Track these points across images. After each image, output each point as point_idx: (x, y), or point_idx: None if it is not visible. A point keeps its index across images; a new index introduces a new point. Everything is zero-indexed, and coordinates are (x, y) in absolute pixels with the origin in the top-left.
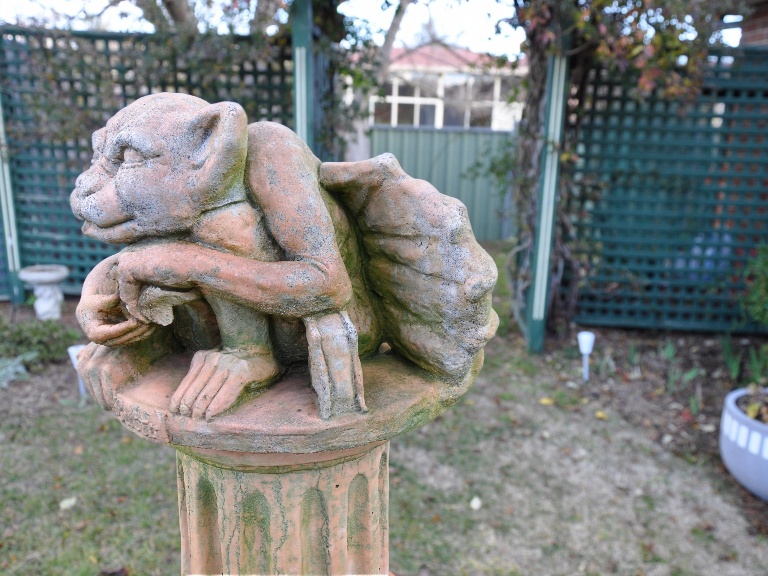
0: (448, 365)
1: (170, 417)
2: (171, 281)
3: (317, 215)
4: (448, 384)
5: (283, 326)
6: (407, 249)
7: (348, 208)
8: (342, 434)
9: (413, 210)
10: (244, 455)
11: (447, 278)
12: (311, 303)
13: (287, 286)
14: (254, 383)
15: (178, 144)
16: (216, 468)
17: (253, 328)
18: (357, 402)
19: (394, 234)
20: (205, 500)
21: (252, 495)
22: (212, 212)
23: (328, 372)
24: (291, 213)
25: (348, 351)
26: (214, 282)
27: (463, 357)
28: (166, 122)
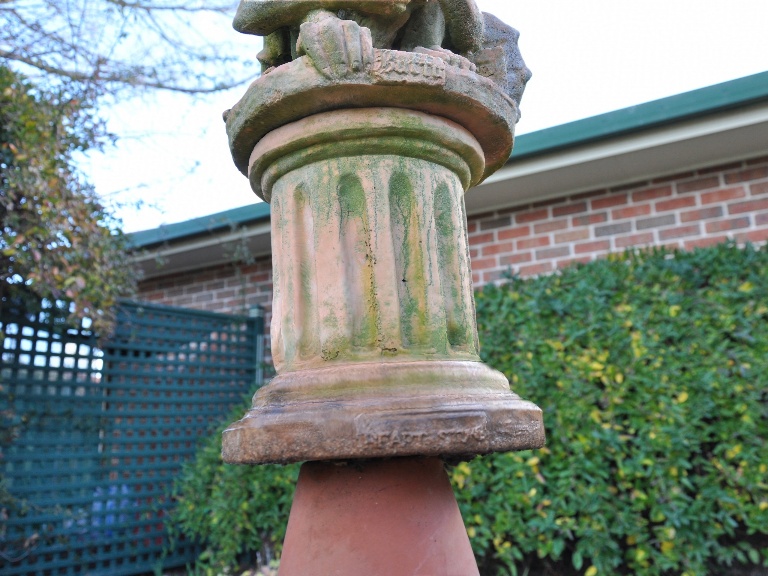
0: None
1: (447, 64)
2: None
3: None
4: None
5: None
6: None
7: None
8: None
9: (484, 25)
10: (459, 131)
11: (508, 67)
12: None
13: None
14: None
15: None
16: (414, 159)
17: None
18: None
19: None
20: None
21: (439, 186)
22: None
23: None
24: None
25: None
26: None
27: None
28: None
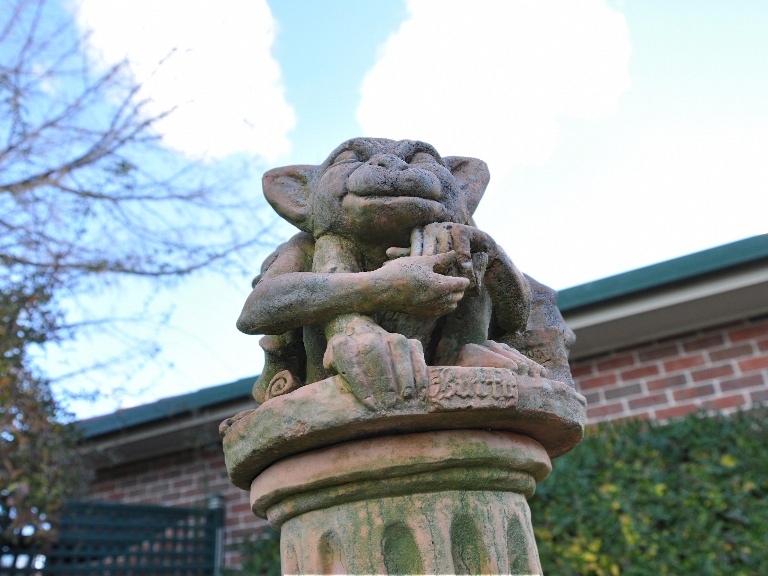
0: None
1: (516, 375)
2: (490, 252)
3: None
4: None
5: None
6: None
7: None
8: None
9: None
10: (529, 447)
11: None
12: None
13: None
14: None
15: None
16: (478, 492)
17: None
18: None
19: None
20: None
21: (510, 522)
22: None
23: None
24: None
25: None
26: (510, 264)
27: None
28: None
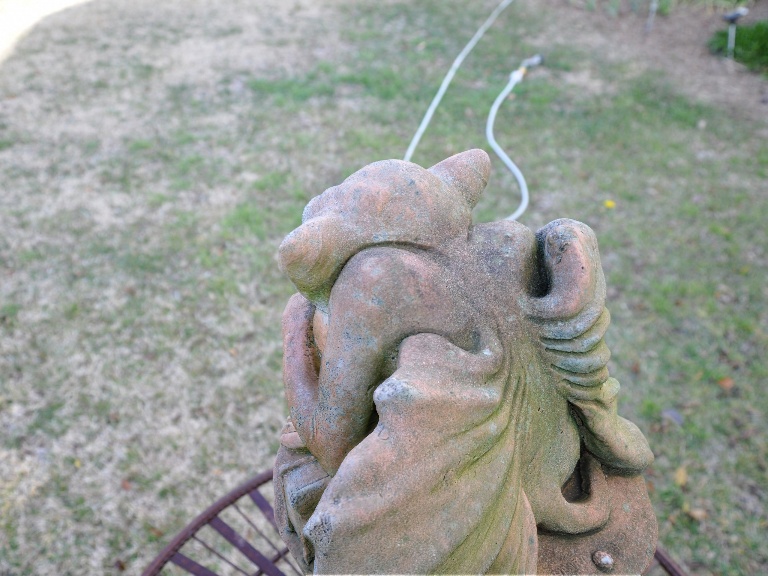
0: None
1: None
2: None
3: (334, 382)
4: None
5: None
6: None
7: None
8: None
9: None
10: None
11: None
12: None
13: None
14: None
15: None
16: None
17: None
18: None
19: None
20: None
21: None
22: None
23: None
24: (323, 361)
25: None
26: None
27: None
28: None
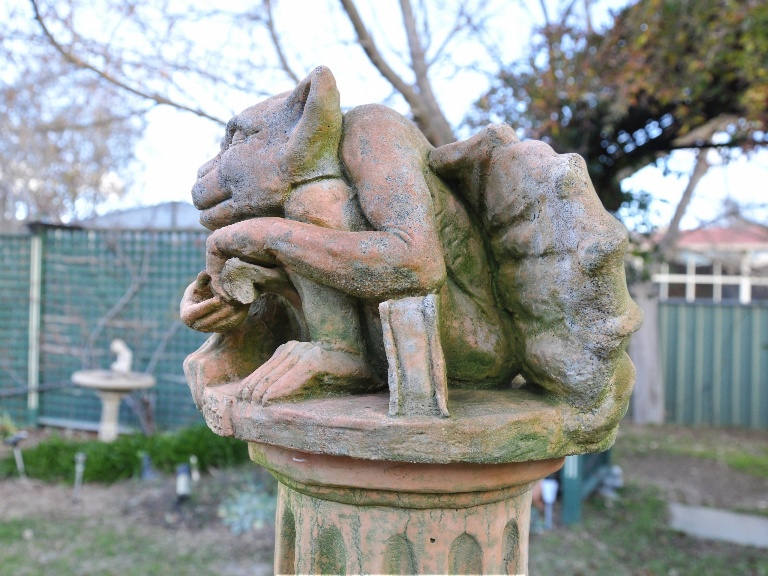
0: (571, 376)
1: (234, 403)
2: (249, 250)
3: (408, 184)
4: (577, 409)
5: (375, 322)
6: (523, 231)
7: (469, 203)
8: (411, 439)
9: (521, 173)
10: (312, 467)
11: (559, 249)
12: (389, 276)
13: (359, 252)
14: (328, 376)
15: (277, 120)
16: (297, 493)
17: (338, 318)
18: (436, 403)
19: (511, 218)
20: (291, 540)
21: (329, 532)
22: (303, 186)
23: (397, 355)
24: (379, 181)
25: (423, 331)
26: (286, 248)
27: (591, 364)
28: (272, 105)
